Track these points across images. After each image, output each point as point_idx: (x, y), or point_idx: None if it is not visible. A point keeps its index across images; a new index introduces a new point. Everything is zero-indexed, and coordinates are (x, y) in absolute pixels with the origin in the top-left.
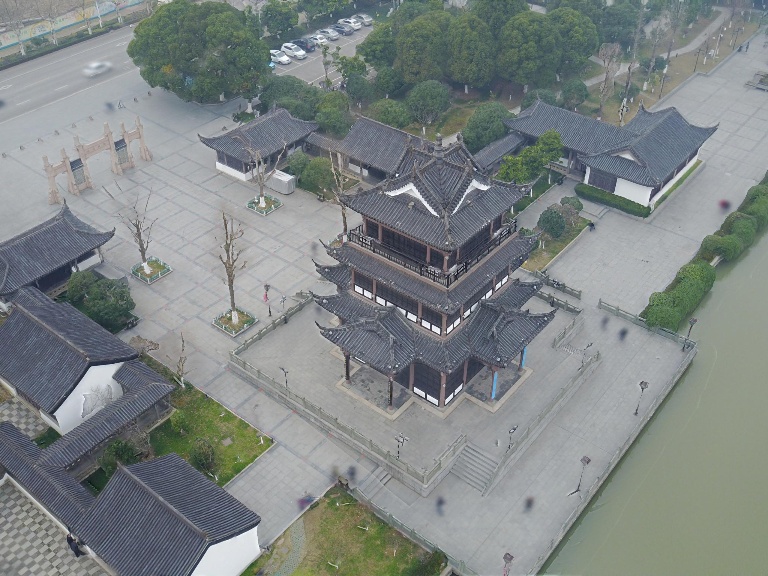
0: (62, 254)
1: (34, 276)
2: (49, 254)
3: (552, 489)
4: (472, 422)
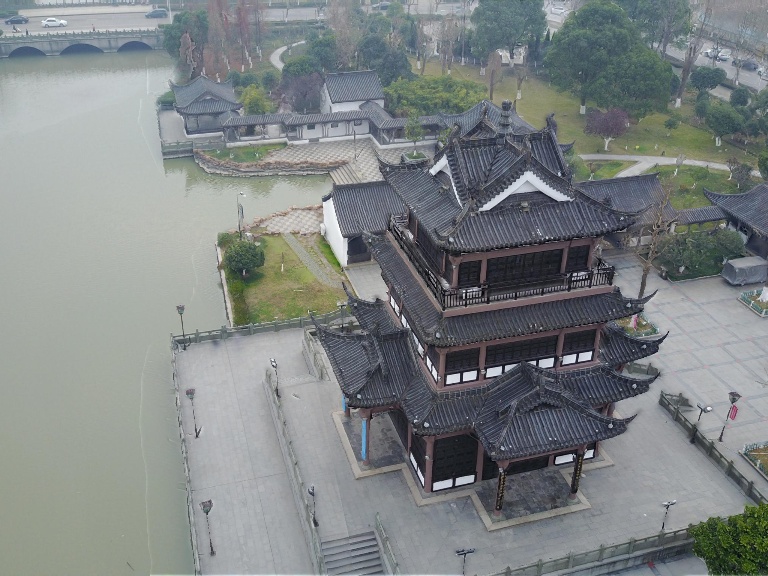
0: (767, 224)
1: (735, 212)
2: (767, 216)
3: (220, 421)
4: (338, 394)
